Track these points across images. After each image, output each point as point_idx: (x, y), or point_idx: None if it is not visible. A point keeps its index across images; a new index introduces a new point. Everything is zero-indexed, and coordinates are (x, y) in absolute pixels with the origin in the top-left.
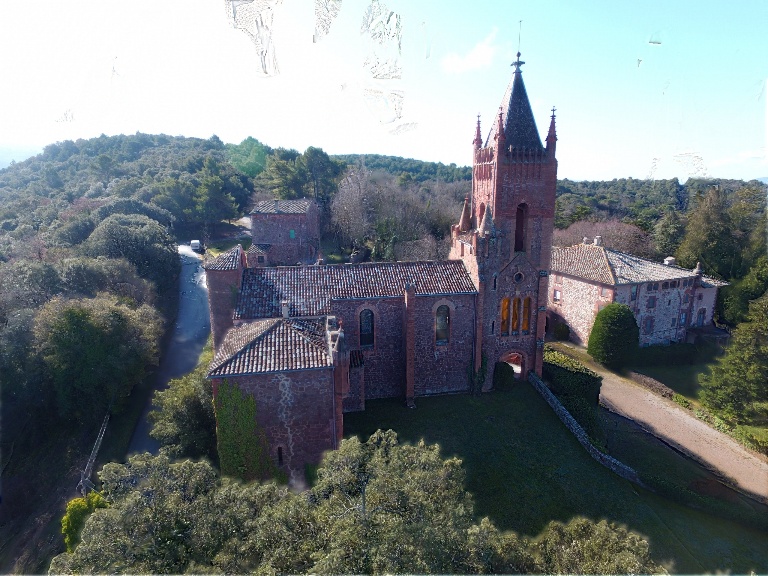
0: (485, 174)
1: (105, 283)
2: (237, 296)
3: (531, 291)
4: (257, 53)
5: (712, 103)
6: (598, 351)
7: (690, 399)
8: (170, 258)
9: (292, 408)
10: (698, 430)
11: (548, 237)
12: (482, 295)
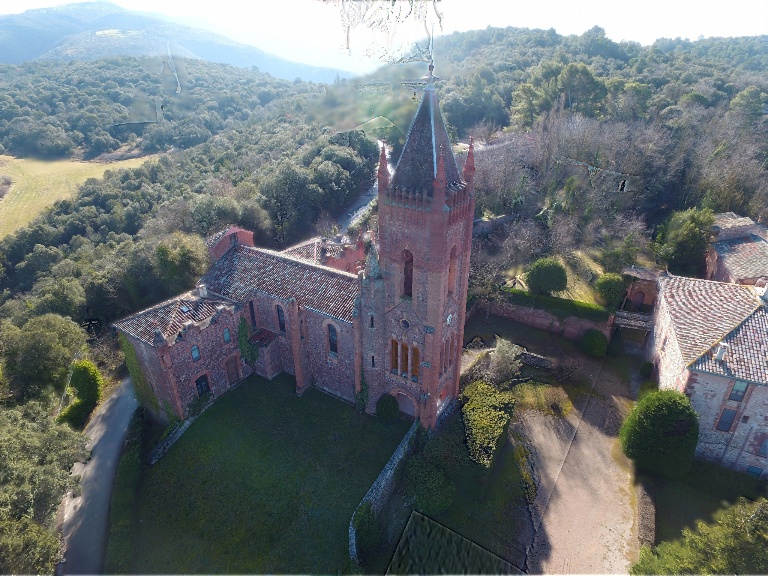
0: None
1: (234, 220)
2: (212, 266)
3: (418, 342)
4: (344, 28)
5: None
6: (623, 438)
7: None
8: (320, 197)
9: (149, 362)
10: None
11: (435, 293)
12: (356, 329)
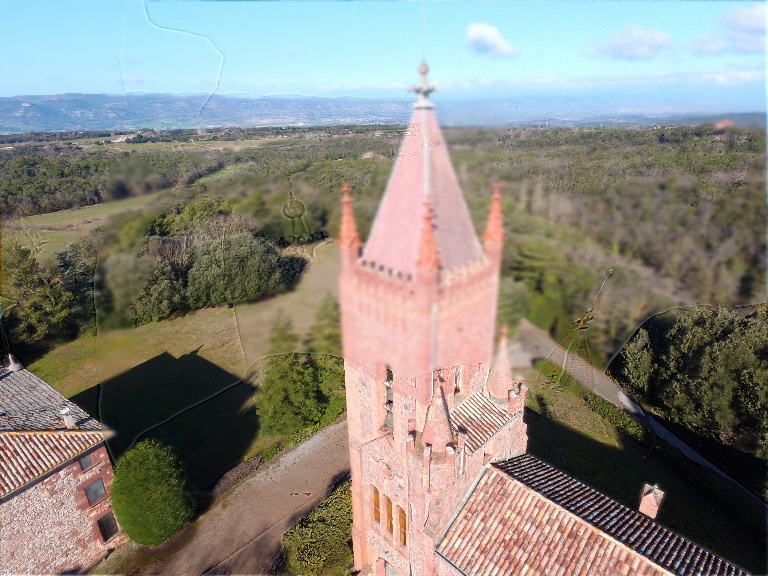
0: None
1: None
2: None
3: None
4: None
5: None
6: (181, 518)
7: (246, 453)
8: None
9: None
10: (320, 445)
11: None
12: None
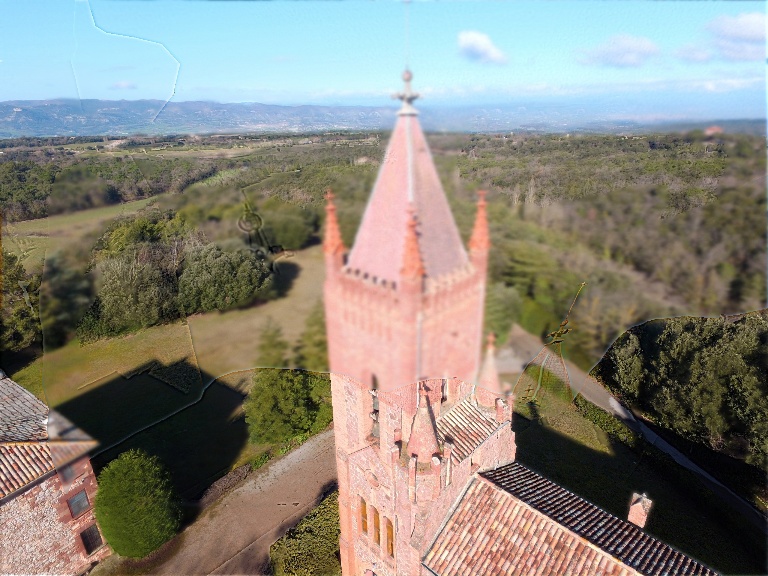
0: None
1: None
2: None
3: None
4: None
5: None
6: (166, 529)
7: (235, 462)
8: None
9: None
10: (310, 454)
11: None
12: None
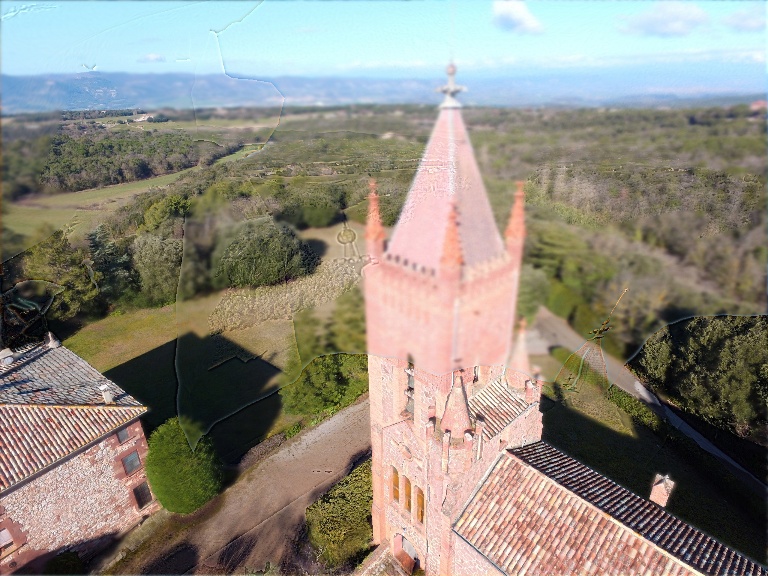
0: None
1: None
2: None
3: None
4: None
5: None
6: (209, 489)
7: (269, 431)
8: None
9: None
10: (340, 426)
11: None
12: None
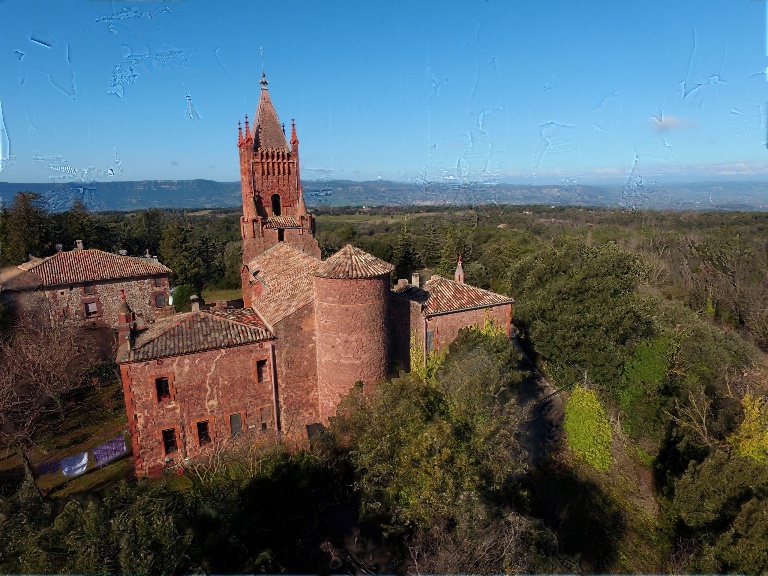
0: (279, 170)
1: None
2: None
3: None
4: None
5: (65, 113)
6: None
7: None
8: None
9: None
10: None
11: None
12: None
